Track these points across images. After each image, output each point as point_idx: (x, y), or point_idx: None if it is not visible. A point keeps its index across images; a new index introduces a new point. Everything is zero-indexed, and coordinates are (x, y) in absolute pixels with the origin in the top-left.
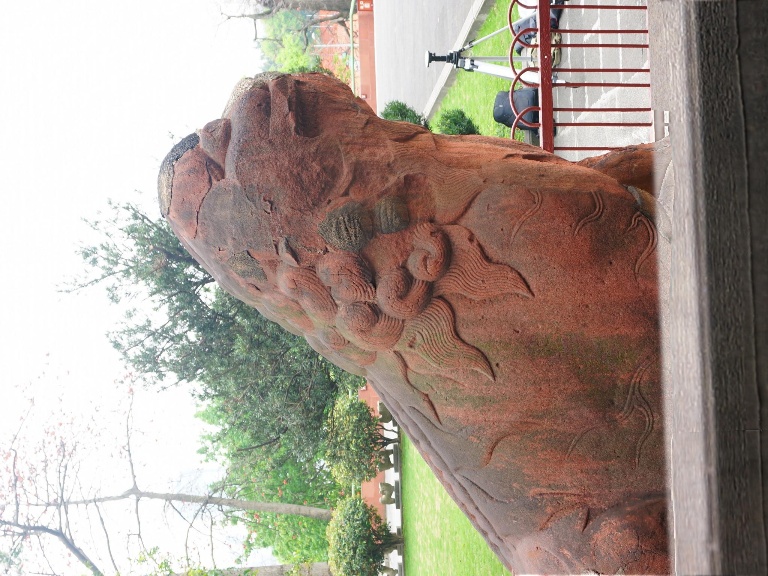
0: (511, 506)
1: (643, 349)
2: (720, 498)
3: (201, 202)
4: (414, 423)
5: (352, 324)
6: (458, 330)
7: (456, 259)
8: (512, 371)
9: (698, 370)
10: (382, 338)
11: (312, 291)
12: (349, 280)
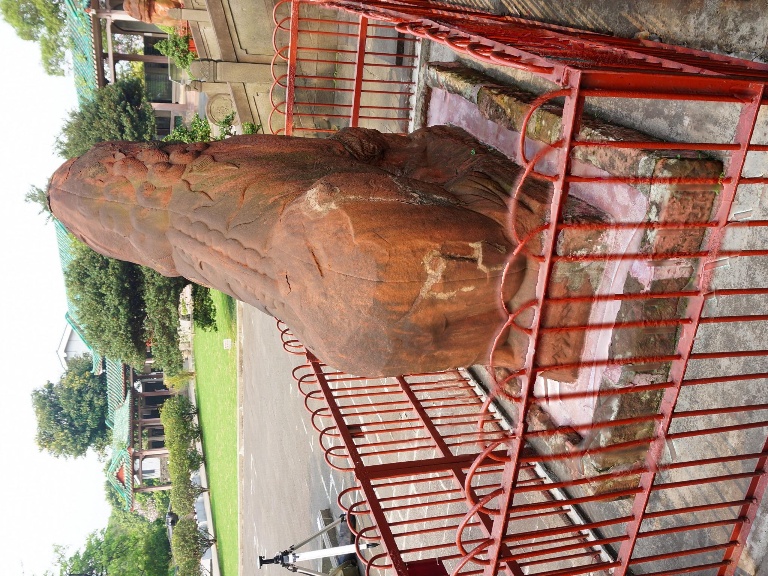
0: (261, 215)
1: (317, 155)
2: None
3: (73, 163)
4: (199, 222)
5: (156, 169)
6: (216, 160)
7: (212, 145)
8: (248, 164)
9: None
10: (174, 172)
11: (133, 163)
12: (154, 152)
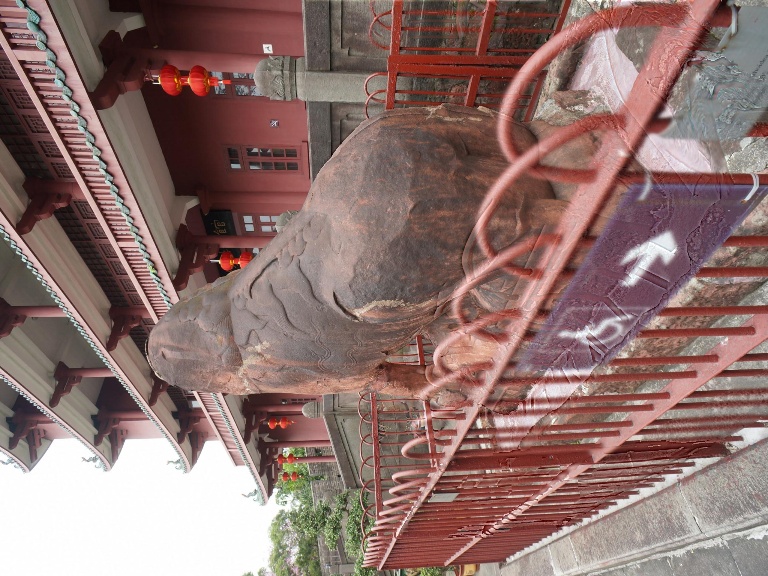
0: None
1: None
2: (321, 129)
3: None
4: None
5: None
6: None
7: None
8: None
9: (318, 154)
10: None
11: None
12: None
